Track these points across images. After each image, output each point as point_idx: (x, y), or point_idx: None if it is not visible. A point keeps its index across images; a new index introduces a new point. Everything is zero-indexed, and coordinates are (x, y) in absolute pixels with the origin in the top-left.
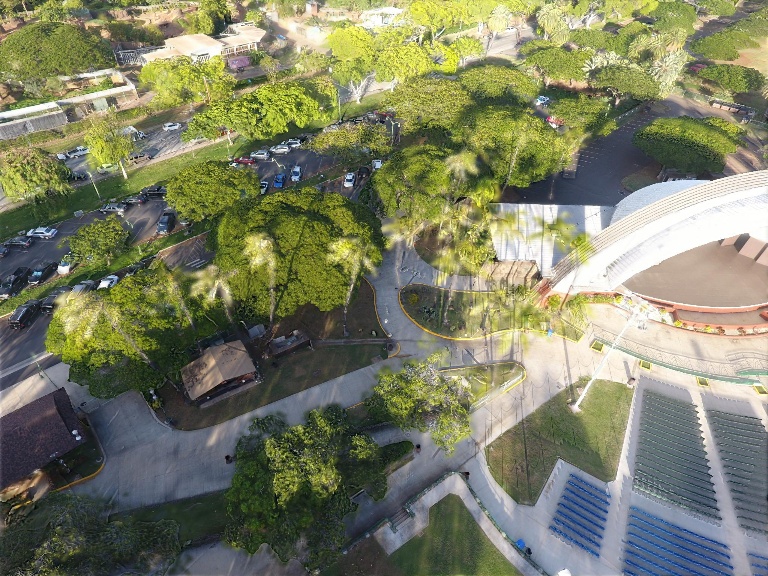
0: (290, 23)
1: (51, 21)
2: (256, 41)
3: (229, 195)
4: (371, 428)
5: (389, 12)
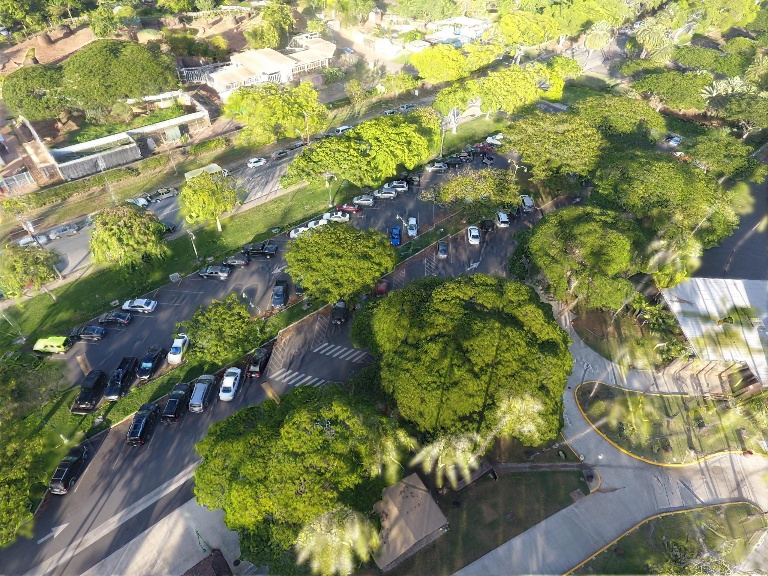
0: (355, 34)
1: (104, 32)
2: (328, 57)
3: (366, 270)
4: None
5: (463, 23)
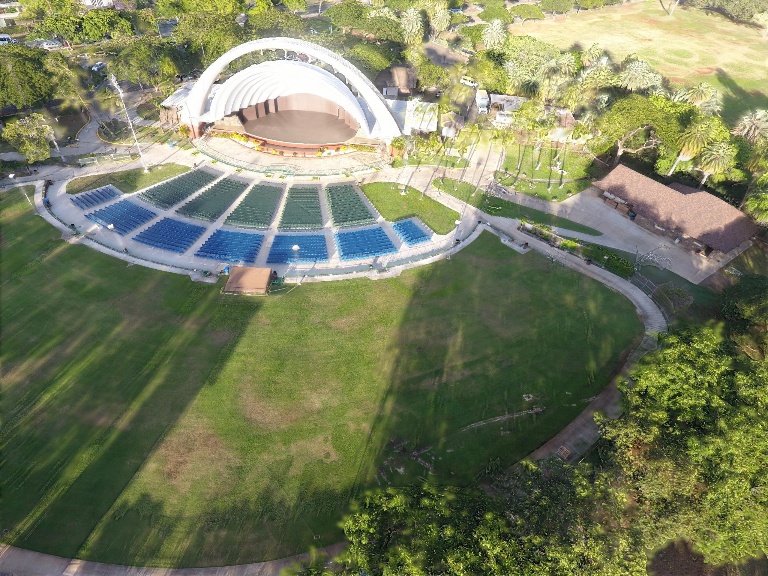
0: None
1: None
2: None
3: None
4: None
5: None
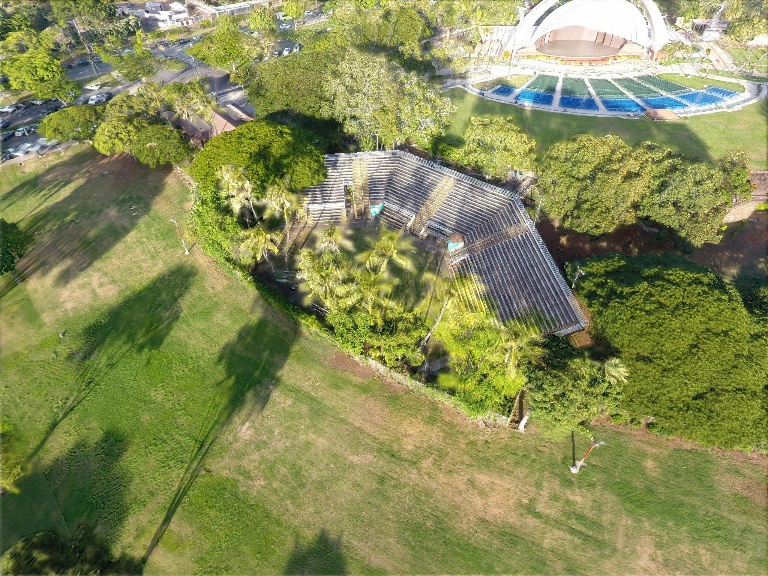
0: None
1: None
2: None
3: (358, 20)
4: None
5: None
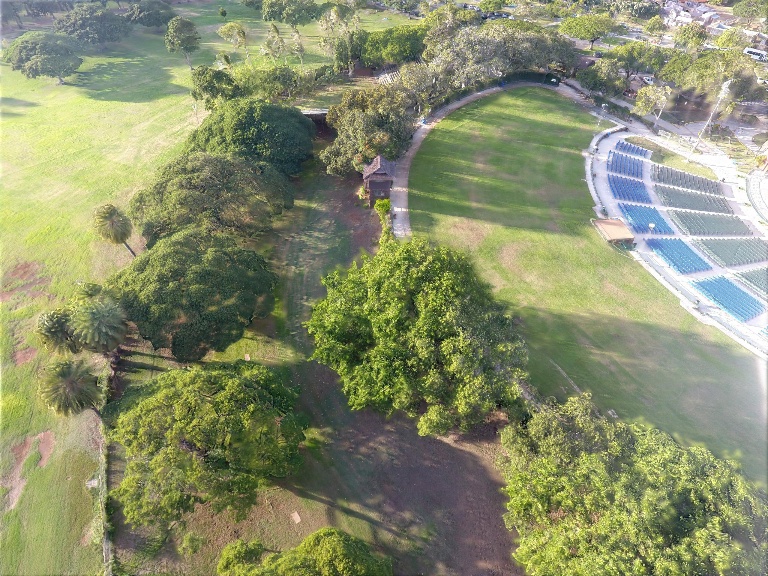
0: None
1: None
2: None
3: None
4: (631, 115)
5: None
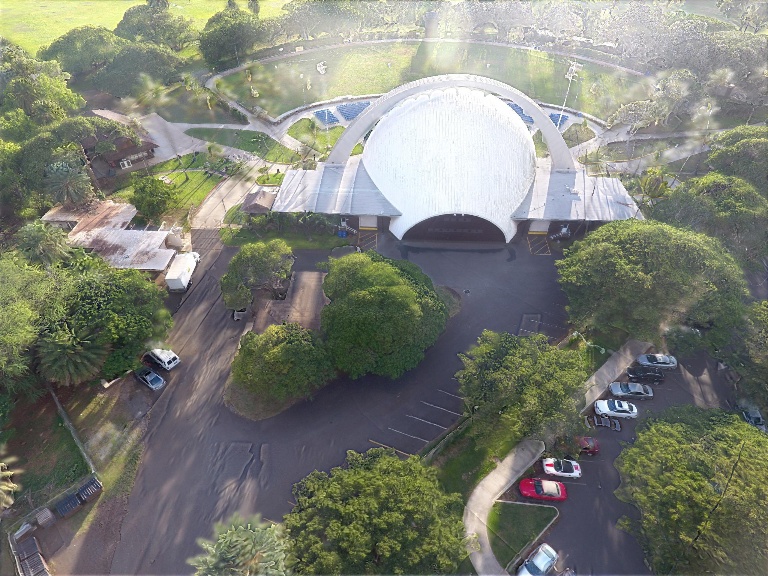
0: None
1: None
2: None
3: None
4: (653, 138)
5: None
